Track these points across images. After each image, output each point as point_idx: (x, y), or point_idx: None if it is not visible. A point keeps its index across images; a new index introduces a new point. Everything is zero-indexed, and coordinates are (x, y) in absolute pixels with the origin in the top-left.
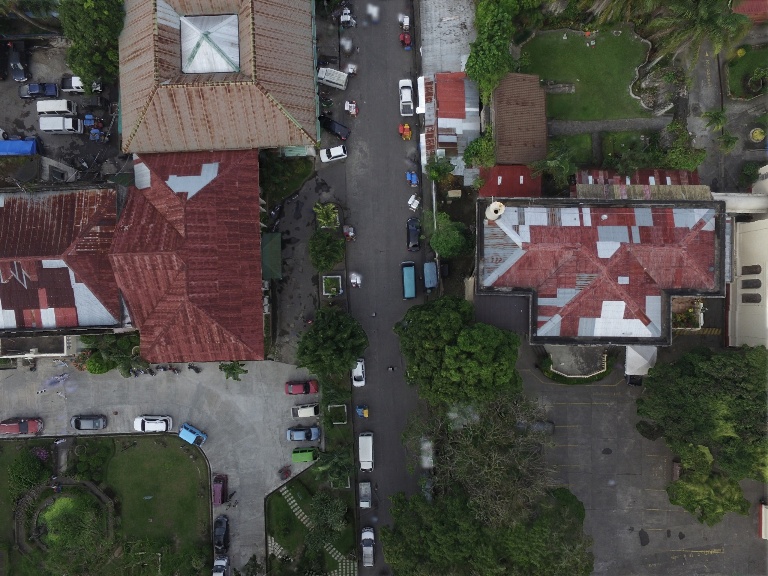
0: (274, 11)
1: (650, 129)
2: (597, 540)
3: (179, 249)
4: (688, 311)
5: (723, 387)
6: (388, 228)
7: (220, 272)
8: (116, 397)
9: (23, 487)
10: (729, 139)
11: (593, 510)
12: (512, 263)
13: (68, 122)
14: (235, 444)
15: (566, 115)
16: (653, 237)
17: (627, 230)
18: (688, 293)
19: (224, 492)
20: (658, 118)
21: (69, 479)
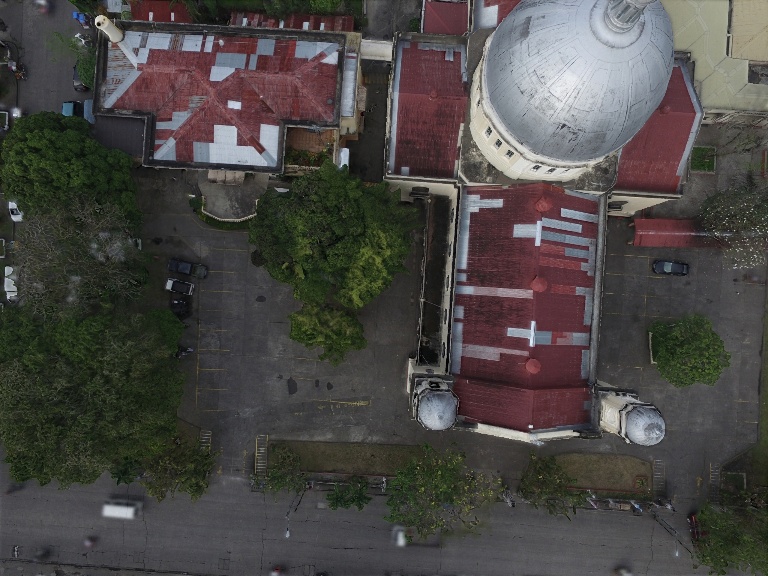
0: None
1: None
2: (245, 386)
3: None
4: (322, 151)
5: (303, 204)
6: (60, 69)
7: None
8: None
9: None
10: None
11: (243, 356)
12: (129, 84)
13: None
14: None
15: None
16: (269, 65)
17: (245, 58)
18: (305, 124)
19: None
20: None
21: None
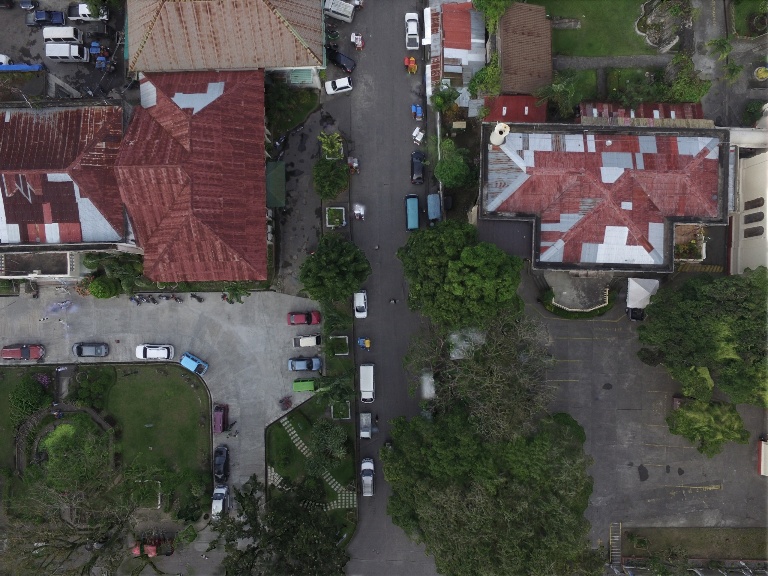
0: None
1: (655, 66)
2: (596, 475)
3: (184, 163)
4: (691, 242)
5: (725, 309)
6: (392, 161)
7: (225, 189)
8: (118, 326)
9: (24, 414)
10: (734, 67)
11: (593, 445)
12: (516, 188)
13: (74, 49)
14: (236, 374)
15: (571, 50)
16: (657, 164)
17: (631, 157)
18: (691, 221)
19: (225, 421)
20: (663, 55)
21: (70, 406)
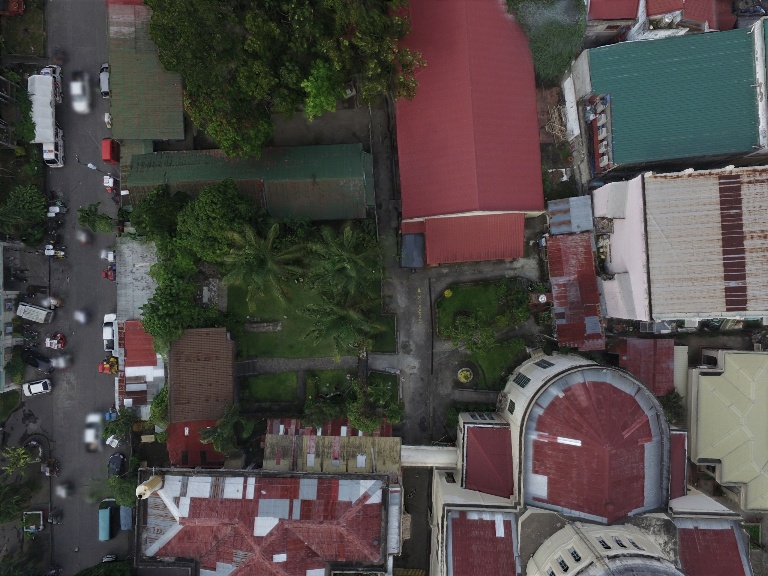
0: None
1: None
2: None
3: None
4: None
5: None
6: (93, 462)
7: None
8: None
9: None
10: (392, 414)
11: None
12: (171, 536)
13: None
14: None
15: (271, 353)
16: (313, 513)
17: (288, 504)
18: (351, 567)
19: None
20: None
21: None
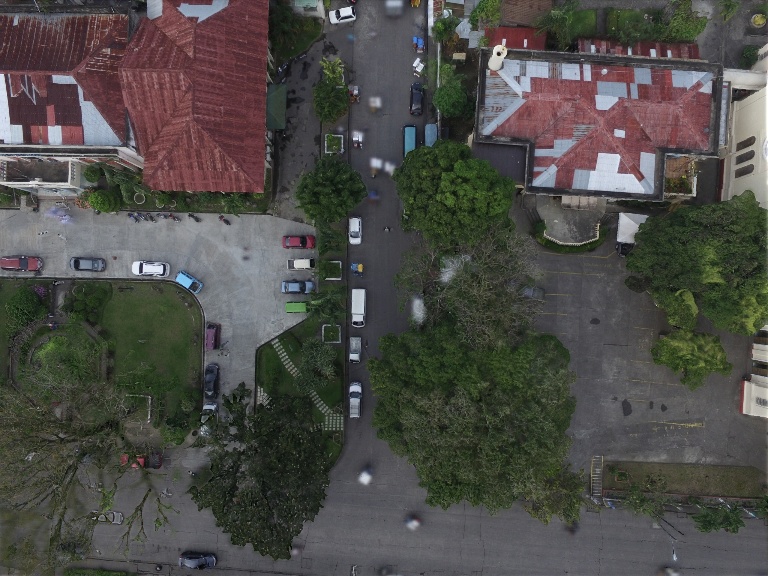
0: None
1: (654, 9)
2: (581, 408)
3: (187, 68)
4: (681, 177)
5: (711, 233)
6: (392, 92)
7: (226, 99)
8: (116, 242)
9: (20, 325)
10: (730, 3)
11: (578, 378)
12: (512, 112)
13: None
14: (230, 295)
15: None
16: (651, 94)
17: (626, 87)
18: (682, 152)
19: (217, 339)
20: None
21: (65, 319)
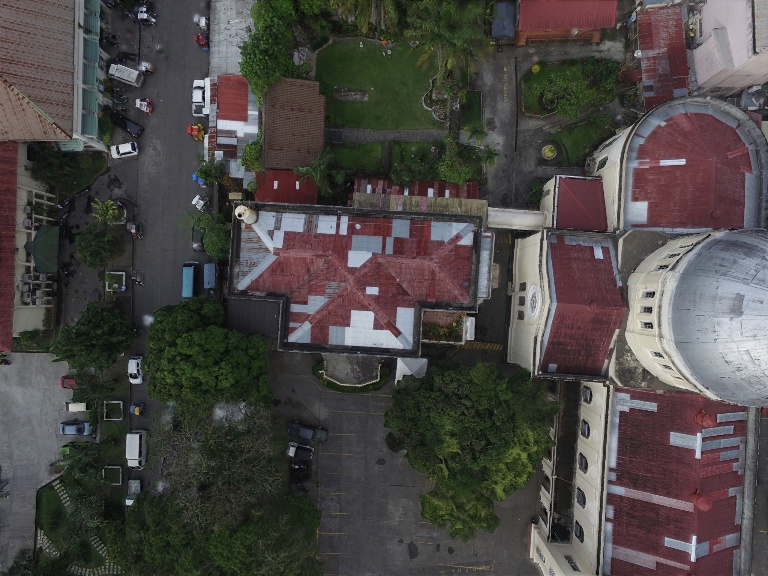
0: (27, 5)
1: (442, 141)
2: (366, 550)
3: None
4: (452, 325)
5: (451, 402)
6: (176, 227)
7: None
8: None
9: None
10: (488, 154)
11: (364, 520)
12: (264, 268)
13: None
14: (11, 435)
15: (357, 123)
16: (406, 249)
17: (382, 240)
18: (441, 307)
19: None
20: None
21: None
